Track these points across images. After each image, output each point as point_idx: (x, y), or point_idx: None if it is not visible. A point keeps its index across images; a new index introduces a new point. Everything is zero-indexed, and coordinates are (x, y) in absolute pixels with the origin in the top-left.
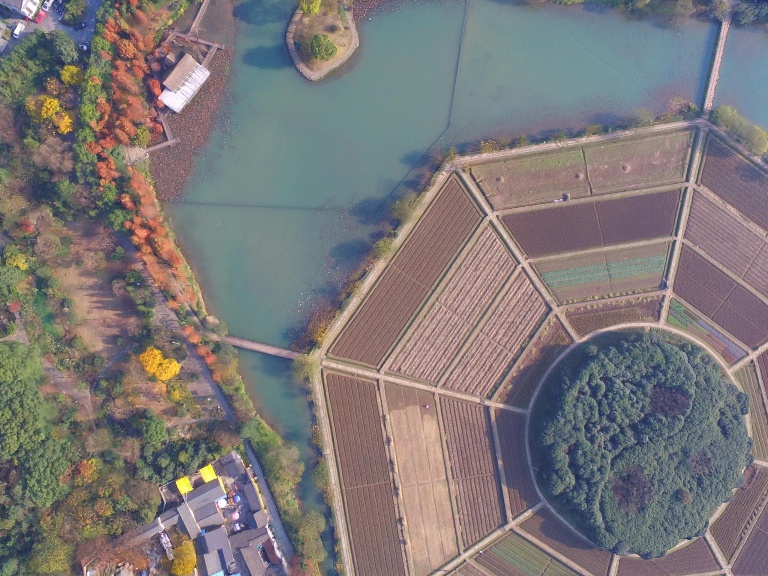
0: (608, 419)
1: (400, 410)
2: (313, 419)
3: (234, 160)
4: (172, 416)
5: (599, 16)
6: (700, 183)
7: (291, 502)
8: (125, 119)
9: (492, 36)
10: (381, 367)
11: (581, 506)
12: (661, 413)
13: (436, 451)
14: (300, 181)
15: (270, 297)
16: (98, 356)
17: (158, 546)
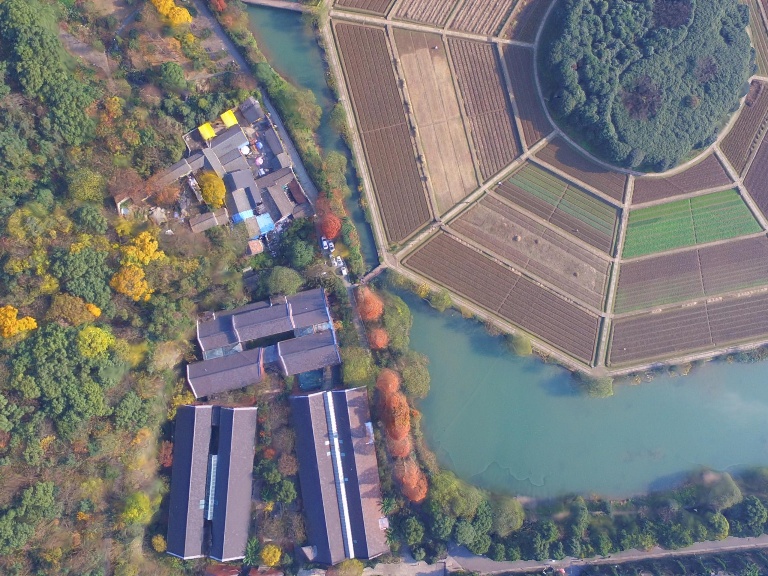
0: (613, 35)
1: (410, 54)
2: (326, 69)
3: None
4: (189, 71)
5: None
6: None
7: (312, 149)
8: None
9: None
10: (388, 13)
11: (593, 118)
12: (664, 24)
13: (448, 90)
14: None
15: None
16: (111, 16)
17: (187, 189)
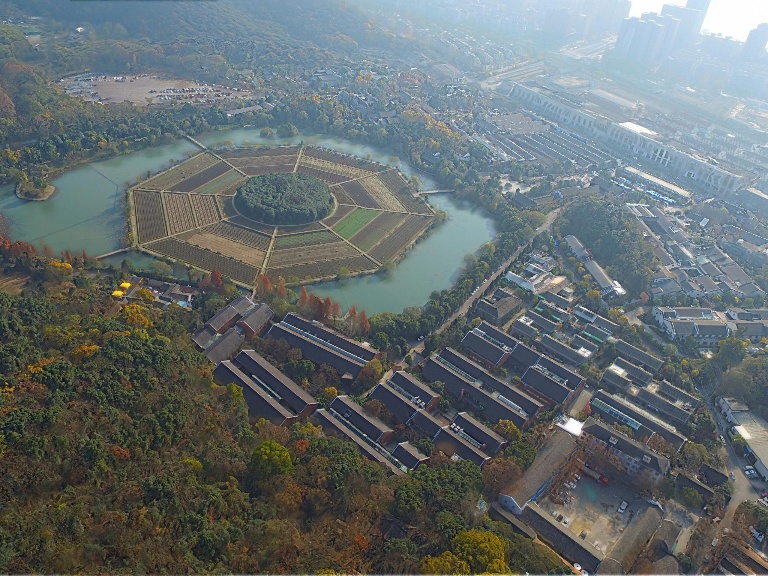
0: None
1: None
2: None
3: None
4: None
5: None
6: None
7: None
8: None
9: (109, 167)
10: None
11: (285, 210)
12: None
13: None
14: None
15: (93, 246)
16: None
17: None
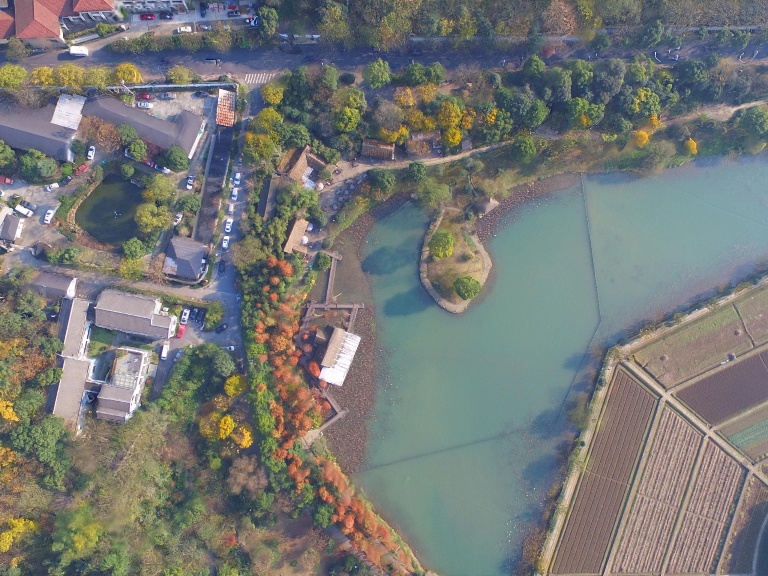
0: None
1: None
2: None
3: (405, 412)
4: None
5: (713, 169)
6: None
7: None
8: (300, 416)
9: (616, 218)
10: (603, 573)
11: None
12: None
13: None
14: (472, 412)
15: (478, 536)
16: None
17: None
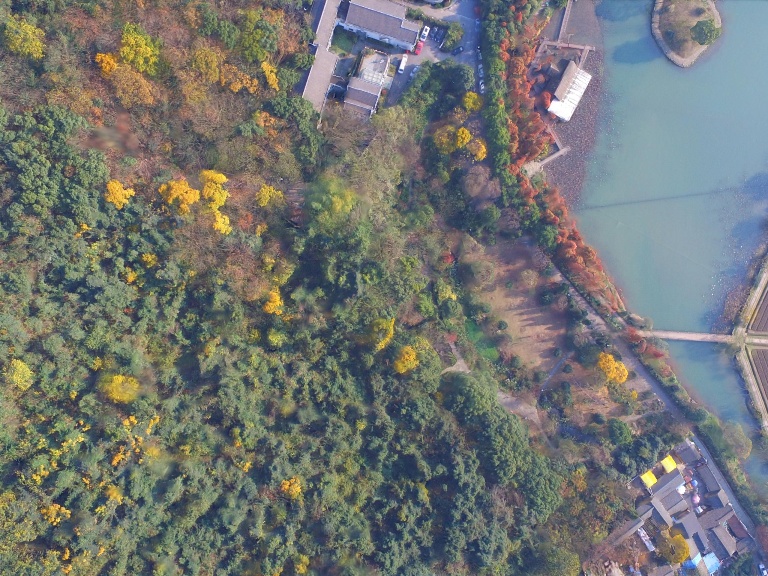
0: None
1: None
2: (745, 395)
3: (623, 159)
4: (618, 416)
5: None
6: None
7: (740, 477)
8: (535, 136)
9: None
10: None
11: None
12: None
13: None
14: (685, 168)
15: (682, 286)
16: (541, 371)
17: (638, 540)
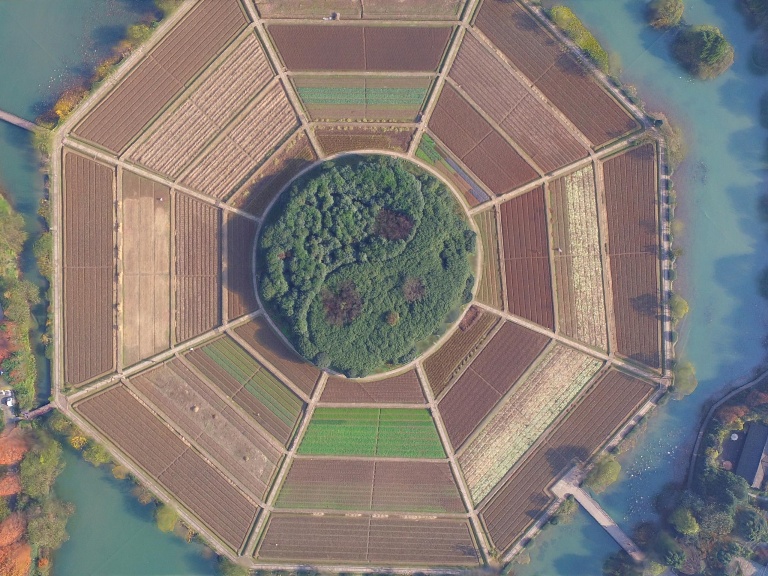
0: (331, 233)
1: (134, 199)
2: (46, 194)
3: None
4: None
5: None
6: (474, 24)
7: (11, 271)
8: None
9: None
10: (122, 154)
11: (287, 312)
12: (383, 234)
13: (163, 245)
14: None
15: (23, 69)
16: None
17: None
